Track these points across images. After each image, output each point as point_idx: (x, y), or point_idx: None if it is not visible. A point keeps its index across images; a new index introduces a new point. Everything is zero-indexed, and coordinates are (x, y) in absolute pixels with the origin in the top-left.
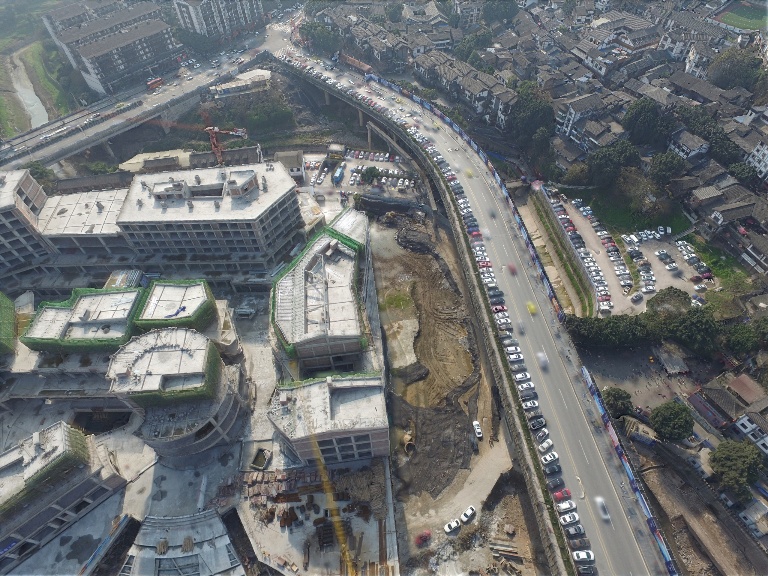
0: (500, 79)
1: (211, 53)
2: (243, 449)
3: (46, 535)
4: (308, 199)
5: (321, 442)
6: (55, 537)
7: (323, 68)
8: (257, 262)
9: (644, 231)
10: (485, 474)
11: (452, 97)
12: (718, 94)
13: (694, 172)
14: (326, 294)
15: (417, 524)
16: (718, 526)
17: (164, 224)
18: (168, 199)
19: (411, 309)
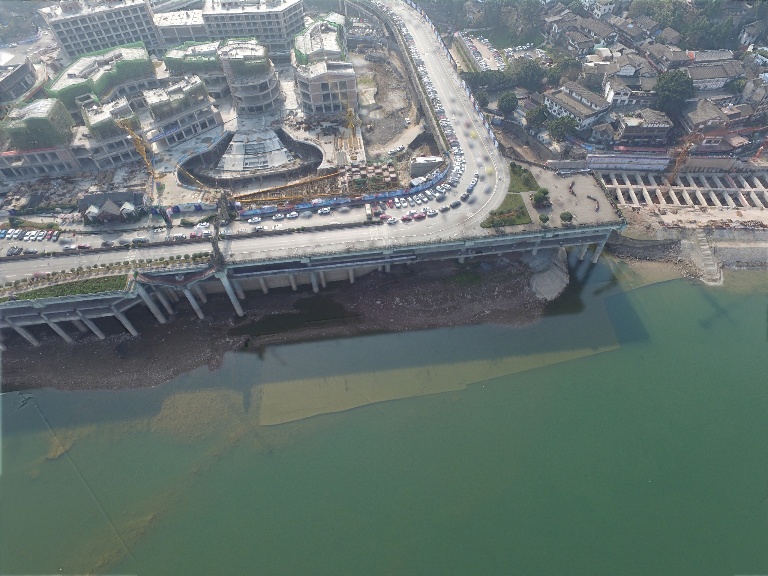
0: None
1: None
2: (282, 112)
3: (189, 136)
4: (308, 20)
5: (323, 86)
6: (193, 138)
7: None
8: (281, 43)
9: (518, 46)
10: (410, 135)
11: None
12: None
13: (549, 11)
14: None
15: (374, 153)
16: (529, 149)
17: (229, 16)
18: (229, 6)
19: (373, 84)
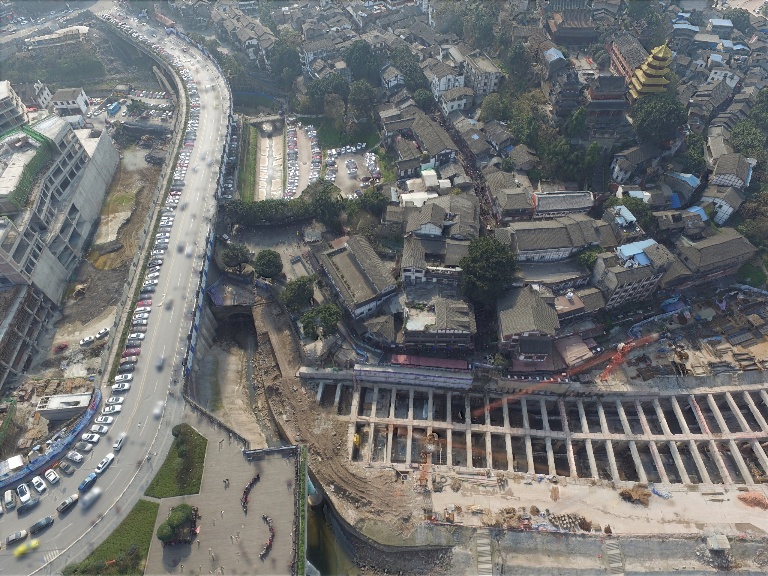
0: (281, 32)
1: (43, 13)
2: None
3: None
4: (43, 115)
5: None
6: None
7: (135, 24)
8: None
9: (346, 147)
10: None
11: (235, 47)
12: None
13: (391, 99)
14: (2, 171)
15: (61, 341)
16: (291, 338)
17: None
18: None
19: (130, 205)
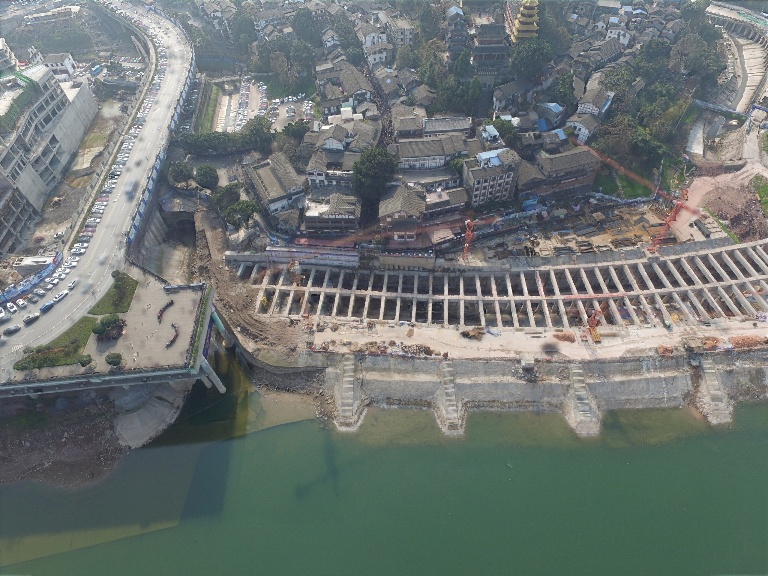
0: None
1: None
2: None
3: None
4: None
5: None
6: None
7: (120, 4)
8: None
9: (288, 97)
10: None
11: (204, 20)
12: None
13: None
14: None
15: (40, 235)
16: (222, 233)
17: None
18: None
19: (103, 142)
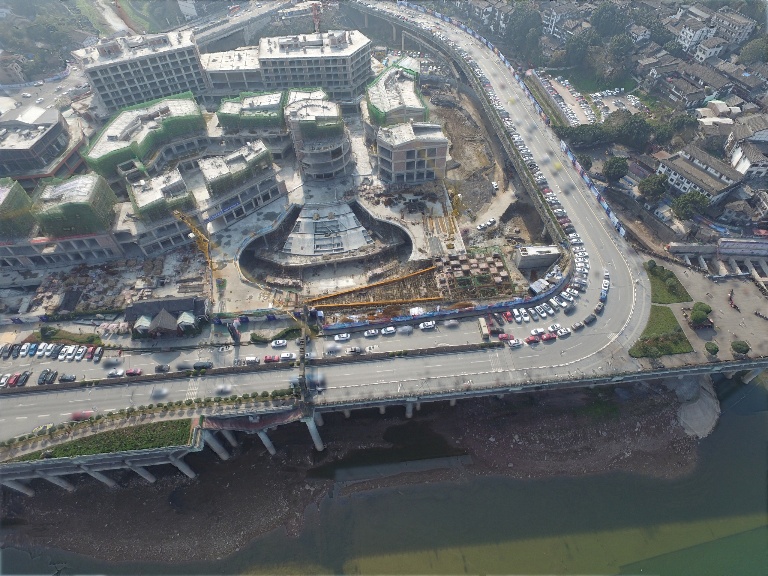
0: None
1: None
2: (354, 179)
3: (249, 210)
4: (374, 61)
5: (408, 153)
6: (253, 212)
7: None
8: (347, 91)
9: (605, 91)
10: (501, 204)
11: (465, 15)
12: (660, 3)
13: (640, 51)
14: None
15: (460, 227)
16: (643, 225)
17: (289, 61)
18: (288, 48)
19: (445, 135)
